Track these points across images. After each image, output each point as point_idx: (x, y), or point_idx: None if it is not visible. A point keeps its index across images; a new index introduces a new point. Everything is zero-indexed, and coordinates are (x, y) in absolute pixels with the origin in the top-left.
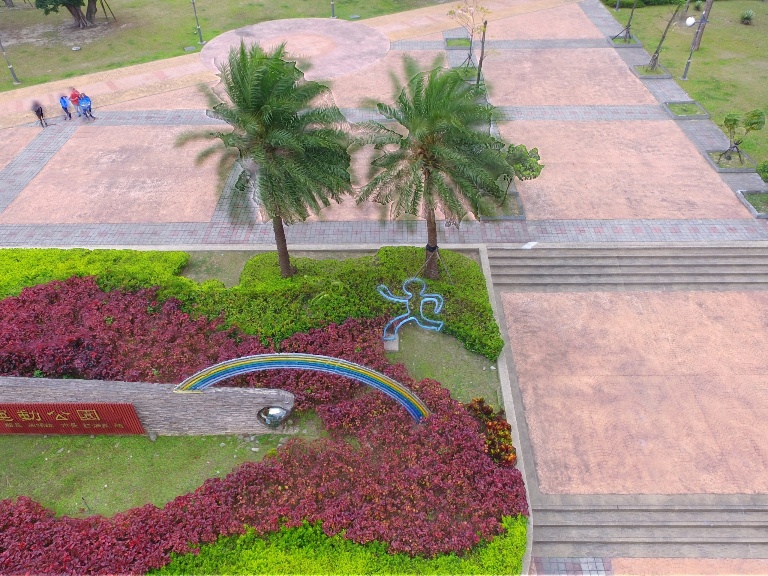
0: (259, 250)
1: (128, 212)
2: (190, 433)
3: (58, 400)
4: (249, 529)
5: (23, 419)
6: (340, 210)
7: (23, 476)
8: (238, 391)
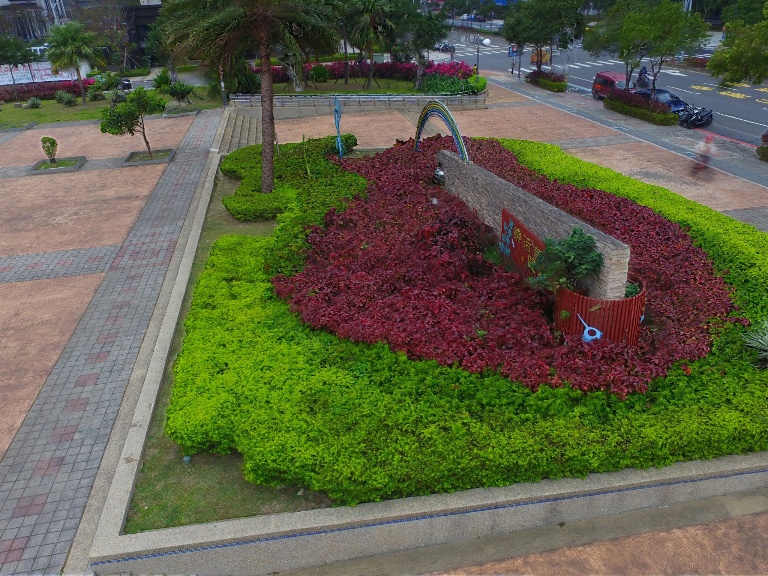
0: (203, 223)
1: (21, 354)
2: None
3: None
4: None
5: None
6: (119, 208)
7: None
8: (453, 155)
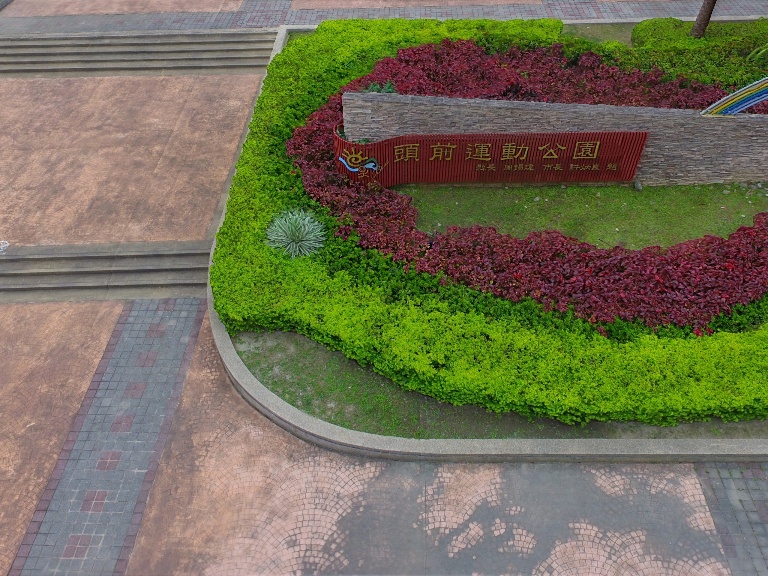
0: (629, 22)
1: None
2: (681, 181)
3: (556, 130)
4: None
5: (504, 157)
6: None
7: (511, 222)
8: None
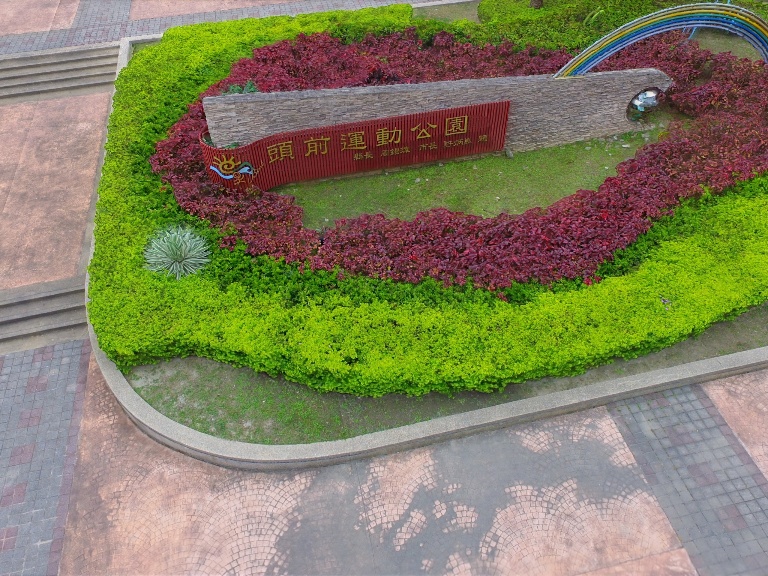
0: (473, 0)
1: None
2: (547, 144)
3: (424, 110)
4: (705, 188)
5: (379, 143)
6: None
7: (397, 206)
8: (618, 73)
